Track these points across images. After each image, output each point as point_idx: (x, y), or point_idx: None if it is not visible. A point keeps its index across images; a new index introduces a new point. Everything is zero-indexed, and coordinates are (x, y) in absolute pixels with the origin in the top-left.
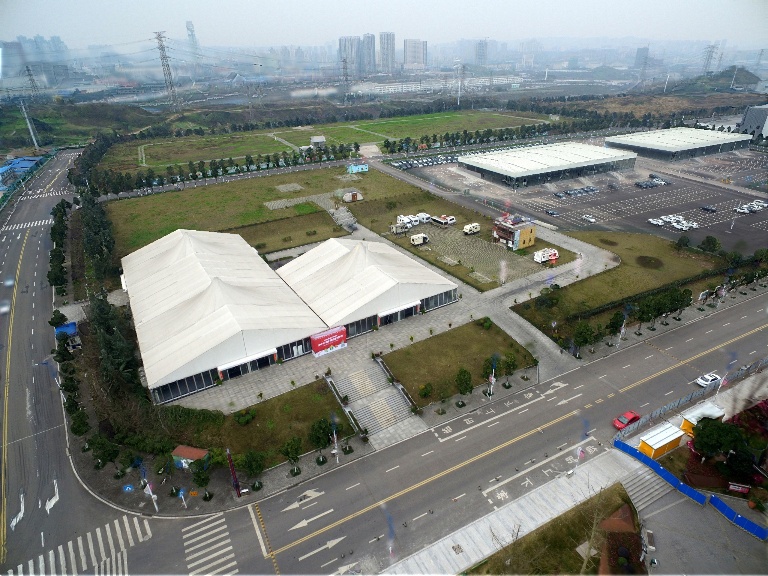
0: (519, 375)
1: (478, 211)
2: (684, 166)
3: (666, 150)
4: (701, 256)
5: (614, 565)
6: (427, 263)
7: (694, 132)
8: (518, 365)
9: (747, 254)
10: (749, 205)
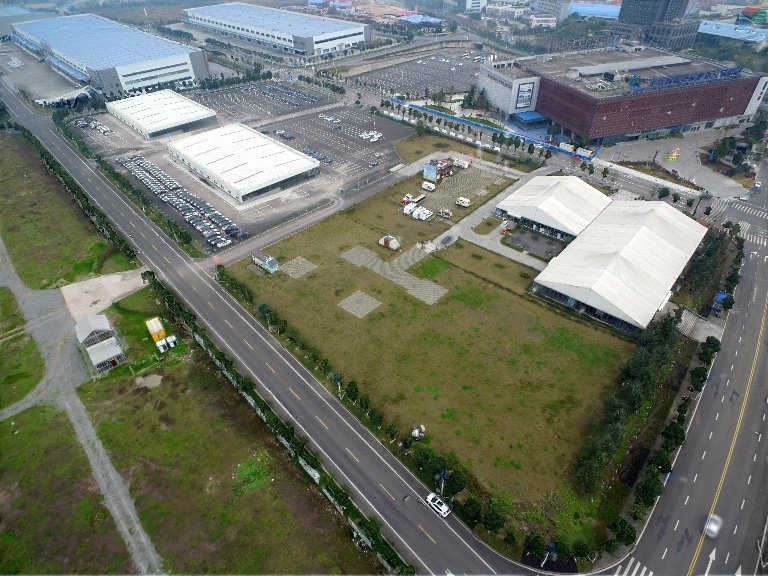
0: (571, 174)
1: (383, 188)
2: (227, 122)
3: (210, 116)
4: (419, 137)
5: (630, 164)
6: (494, 198)
7: (140, 102)
8: (565, 174)
9: (408, 129)
10: (331, 118)
